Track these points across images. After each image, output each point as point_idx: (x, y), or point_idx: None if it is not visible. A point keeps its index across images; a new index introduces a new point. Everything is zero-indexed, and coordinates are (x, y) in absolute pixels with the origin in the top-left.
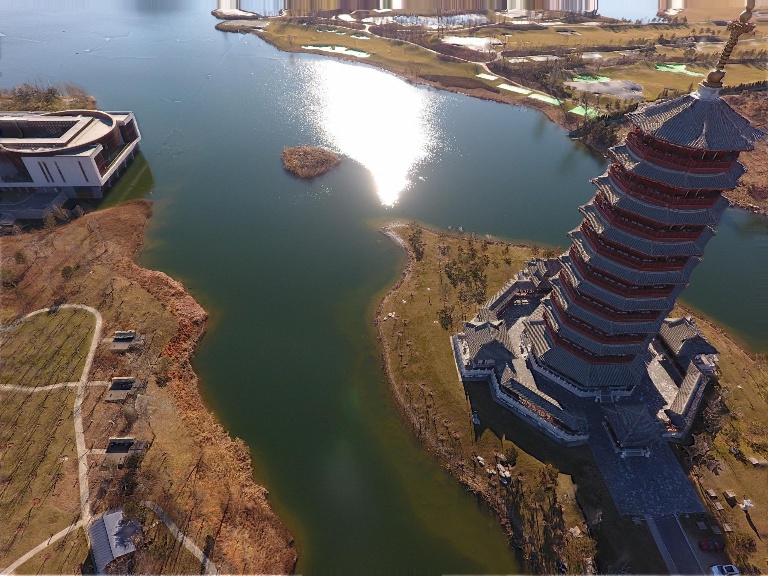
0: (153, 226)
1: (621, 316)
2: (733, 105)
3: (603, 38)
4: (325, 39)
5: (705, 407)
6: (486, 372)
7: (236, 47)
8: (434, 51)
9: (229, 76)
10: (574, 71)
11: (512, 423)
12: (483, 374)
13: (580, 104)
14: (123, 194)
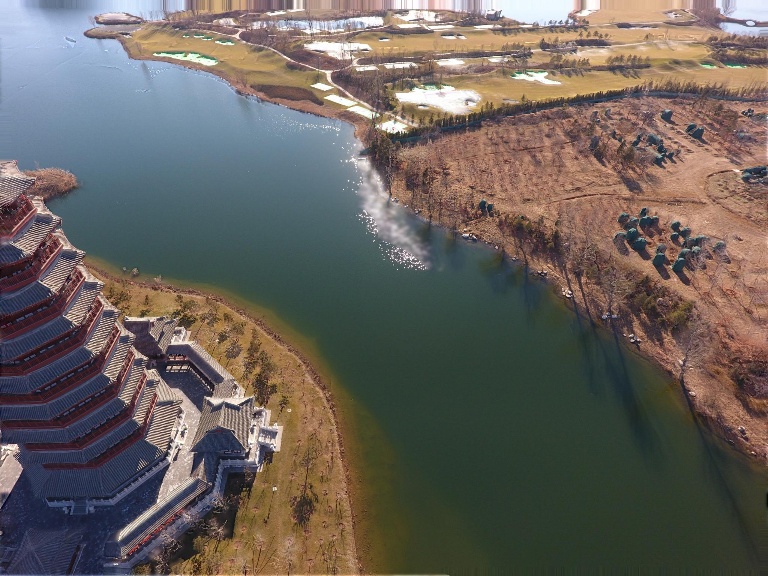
0: None
1: (12, 423)
2: (557, 119)
3: (485, 42)
4: (185, 45)
5: (205, 520)
6: None
7: (85, 55)
8: (289, 58)
9: (43, 87)
10: (419, 80)
11: None
12: None
13: (394, 118)
14: None
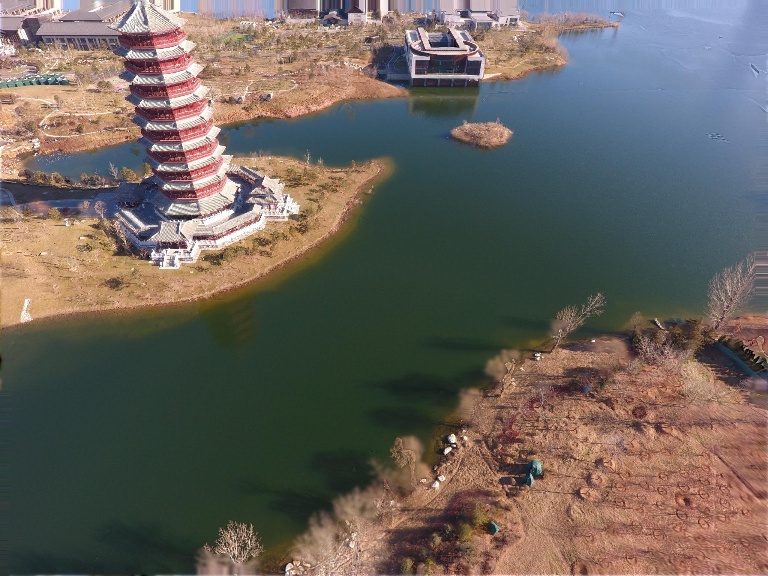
0: (380, 100)
1: None
2: None
3: None
4: None
5: None
6: None
7: None
8: None
9: (666, 95)
10: None
11: None
12: None
13: None
14: (416, 89)
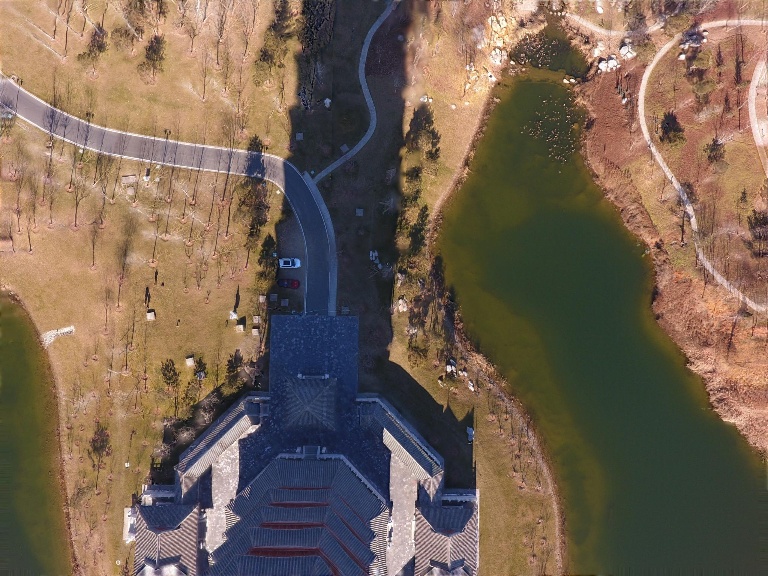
0: None
1: None
2: None
3: None
4: None
5: None
6: (448, 498)
7: None
8: None
9: None
10: None
11: (431, 426)
12: (451, 496)
13: None
14: None
